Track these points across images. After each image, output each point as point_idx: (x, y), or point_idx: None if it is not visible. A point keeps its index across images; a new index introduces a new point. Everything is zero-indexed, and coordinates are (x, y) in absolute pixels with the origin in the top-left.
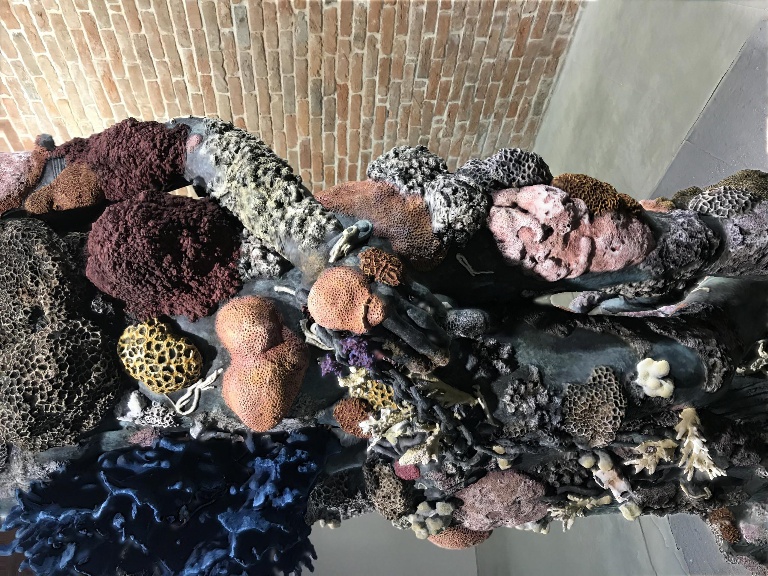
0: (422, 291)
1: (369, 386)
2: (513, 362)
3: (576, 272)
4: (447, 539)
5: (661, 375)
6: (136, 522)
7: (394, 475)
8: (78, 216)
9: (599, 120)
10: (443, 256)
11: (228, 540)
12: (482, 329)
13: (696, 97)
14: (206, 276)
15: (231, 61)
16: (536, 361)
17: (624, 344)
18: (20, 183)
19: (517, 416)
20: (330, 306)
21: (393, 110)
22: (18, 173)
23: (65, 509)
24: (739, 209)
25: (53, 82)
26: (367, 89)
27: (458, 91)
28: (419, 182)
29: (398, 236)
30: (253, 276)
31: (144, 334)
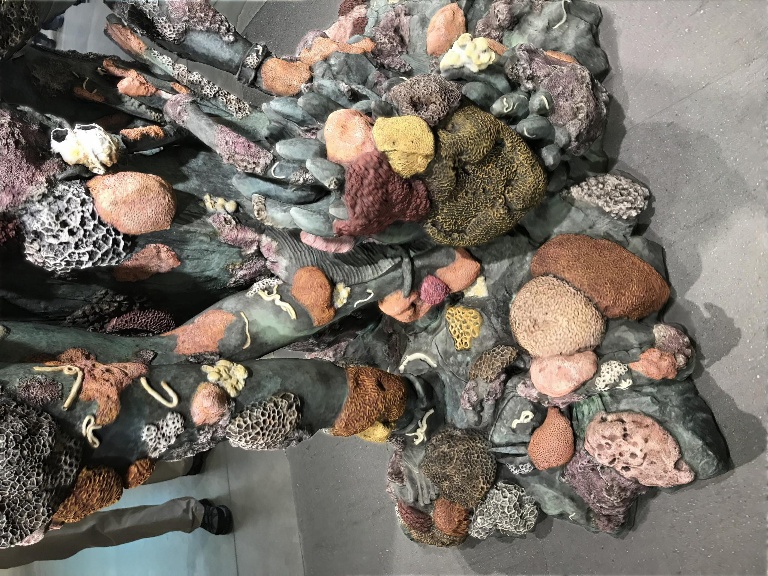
0: None
1: None
2: None
3: None
4: None
5: None
6: None
7: None
8: None
9: None
10: None
11: None
12: None
13: None
14: None
15: None
16: None
17: None
18: None
19: None
20: None
21: None
22: None
23: None
24: None
25: None
26: None
27: None
28: None
29: None
30: None
31: None
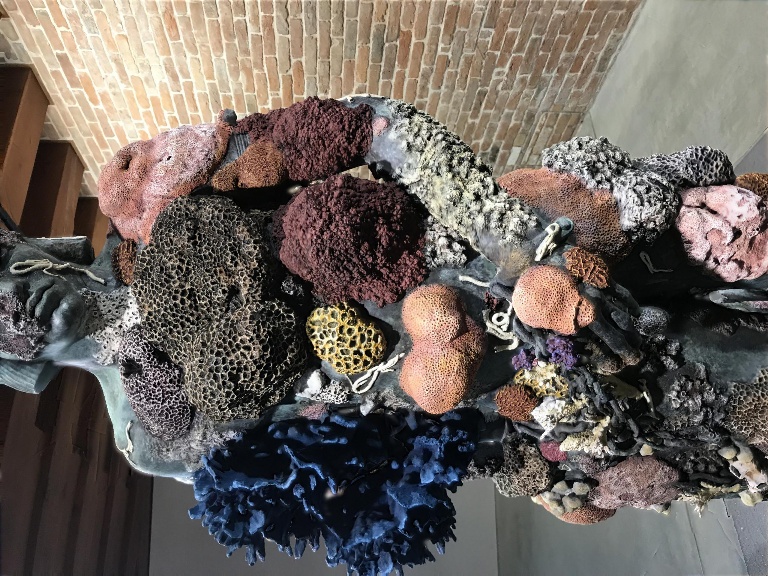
0: (625, 293)
1: (557, 380)
2: (680, 358)
3: (755, 274)
4: (574, 515)
5: None
6: (314, 493)
7: (541, 456)
8: (261, 194)
9: (673, 82)
10: (627, 253)
11: (390, 511)
12: (664, 328)
13: None
14: (396, 263)
15: (295, 2)
16: (702, 359)
17: None
18: (208, 159)
19: (680, 411)
20: (541, 306)
21: (454, 60)
22: (206, 149)
23: (253, 479)
24: None
25: (113, 16)
26: (431, 37)
27: (524, 43)
28: (608, 177)
29: (585, 231)
30: (439, 264)
31: (336, 318)
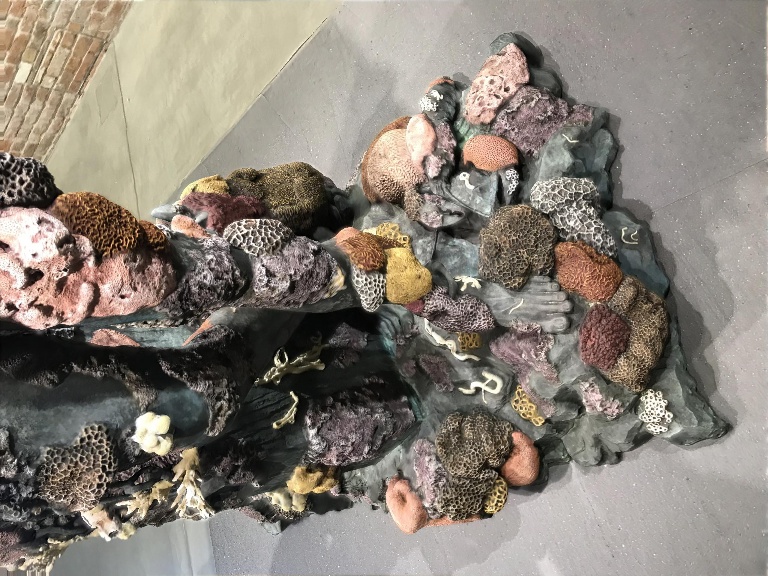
0: None
1: None
2: None
3: (72, 320)
4: None
5: (159, 433)
6: None
7: None
8: None
9: (189, 32)
10: None
11: None
12: None
13: (280, 48)
14: None
15: None
16: (8, 422)
17: (126, 393)
18: None
19: None
20: None
21: None
22: None
23: None
24: (269, 248)
25: None
26: None
27: None
28: None
29: None
30: None
31: None
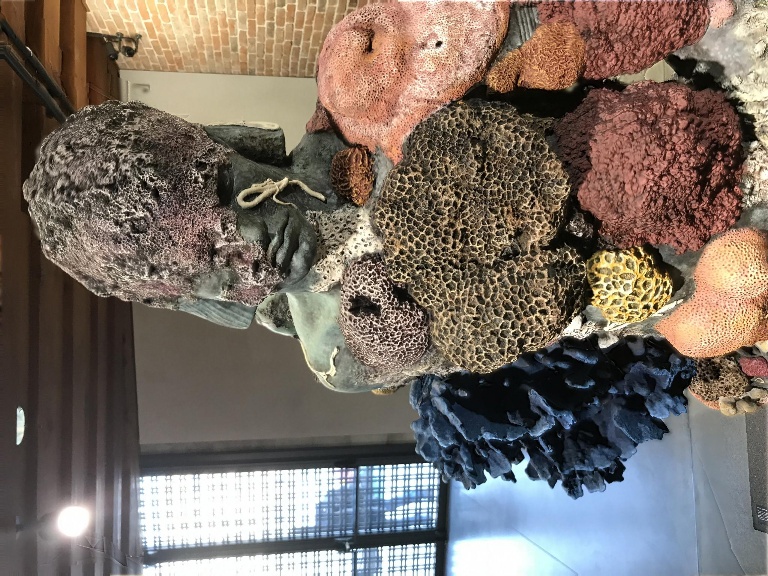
0: None
1: None
2: None
3: None
4: None
5: None
6: None
7: (741, 372)
8: (541, 96)
9: None
10: None
11: (600, 433)
12: None
13: None
14: (712, 204)
15: None
16: None
17: None
18: (488, 47)
19: None
20: None
21: None
22: (487, 32)
23: (499, 425)
24: None
25: None
26: None
27: None
28: None
29: None
30: (754, 204)
31: (633, 269)
